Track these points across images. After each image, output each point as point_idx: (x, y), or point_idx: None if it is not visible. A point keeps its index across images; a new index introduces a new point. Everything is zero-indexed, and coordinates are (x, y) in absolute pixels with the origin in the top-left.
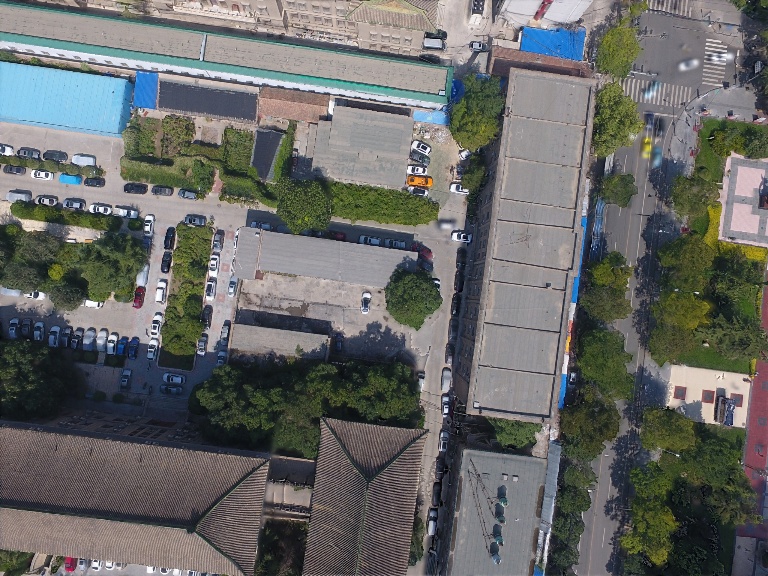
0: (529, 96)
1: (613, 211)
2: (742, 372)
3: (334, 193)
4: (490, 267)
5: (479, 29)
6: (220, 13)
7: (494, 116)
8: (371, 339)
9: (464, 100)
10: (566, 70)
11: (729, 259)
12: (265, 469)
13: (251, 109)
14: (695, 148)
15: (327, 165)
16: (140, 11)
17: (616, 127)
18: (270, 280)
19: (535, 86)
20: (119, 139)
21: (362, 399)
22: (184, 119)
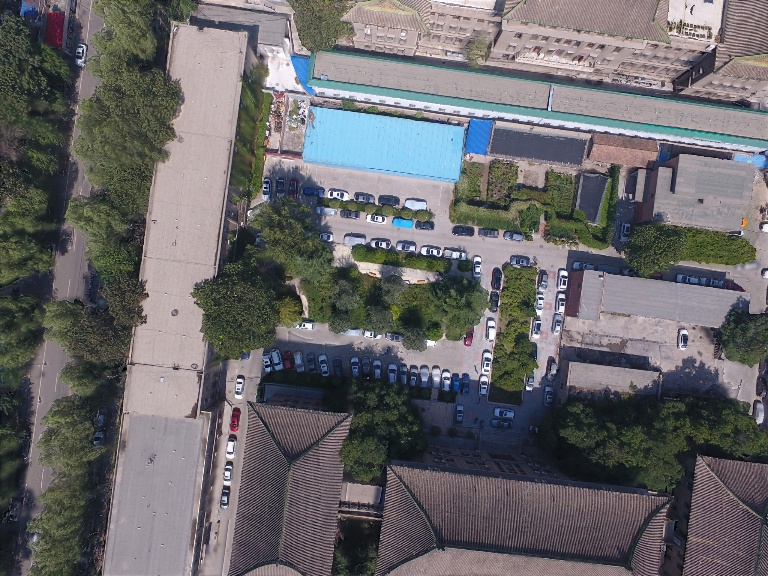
0: None
1: None
2: None
3: None
4: None
5: None
6: (562, 63)
7: None
8: (686, 373)
9: None
10: None
11: None
12: (666, 507)
13: (578, 154)
14: None
15: (668, 210)
16: (466, 59)
17: None
18: None
19: None
20: (448, 183)
21: (723, 436)
22: None
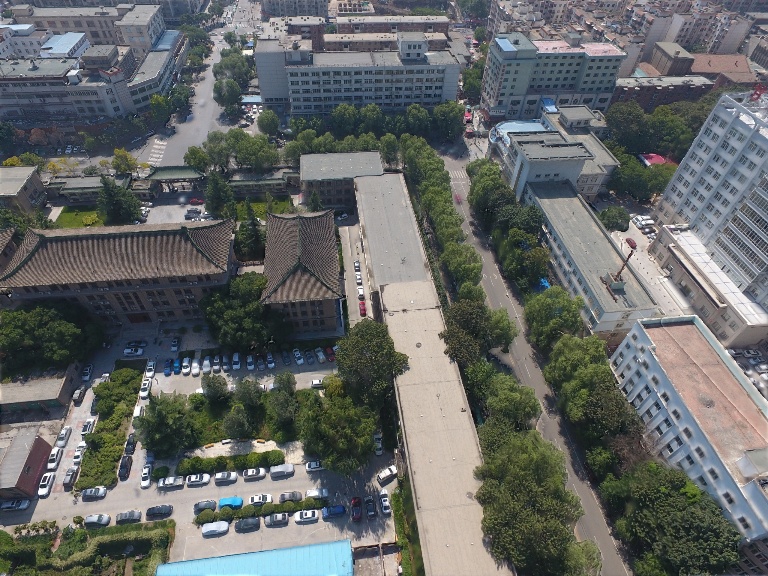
0: None
1: None
2: None
3: None
4: None
5: None
6: None
7: None
8: None
9: None
10: None
11: None
12: None
13: None
14: None
15: None
16: None
17: None
18: None
19: None
20: None
21: None
22: None
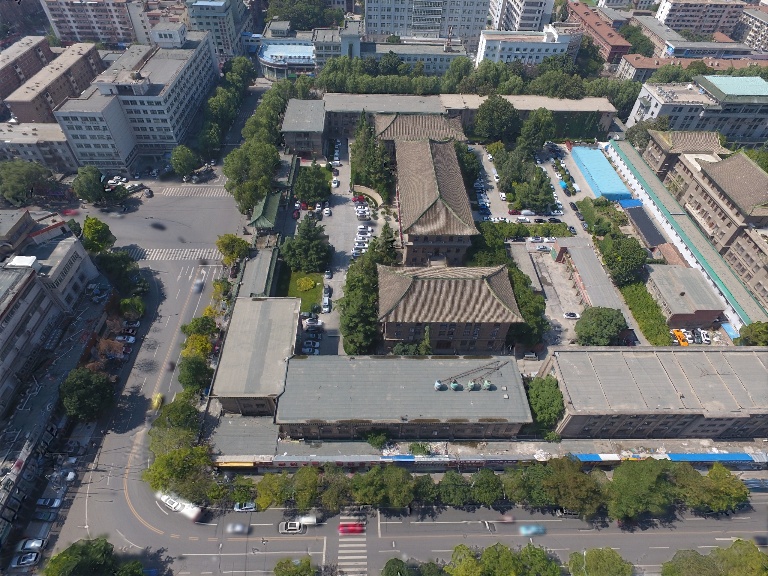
0: None
1: None
2: None
3: (637, 285)
4: (666, 350)
5: None
6: None
7: None
8: None
9: None
10: None
11: None
12: (472, 233)
13: (657, 243)
14: None
15: (656, 271)
16: None
17: None
18: (557, 266)
19: None
20: None
21: None
22: None
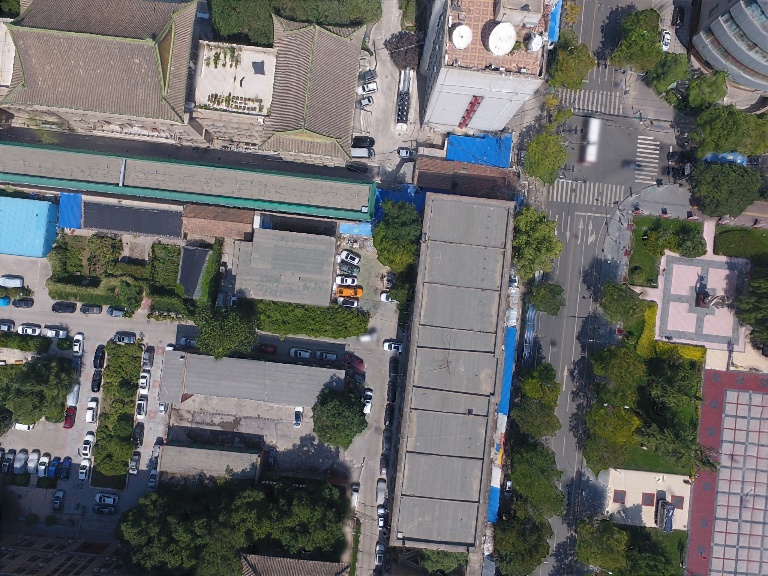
0: (446, 220)
1: (547, 314)
2: (682, 474)
3: (261, 309)
4: (410, 396)
5: (406, 134)
6: (140, 136)
7: (413, 239)
8: (304, 452)
9: (382, 224)
10: (492, 179)
11: (666, 359)
12: None
13: (176, 226)
14: (629, 248)
15: (250, 286)
16: (64, 129)
17: (533, 253)
18: (201, 395)
19: (452, 210)
20: (46, 259)
21: (286, 530)
22: (109, 238)
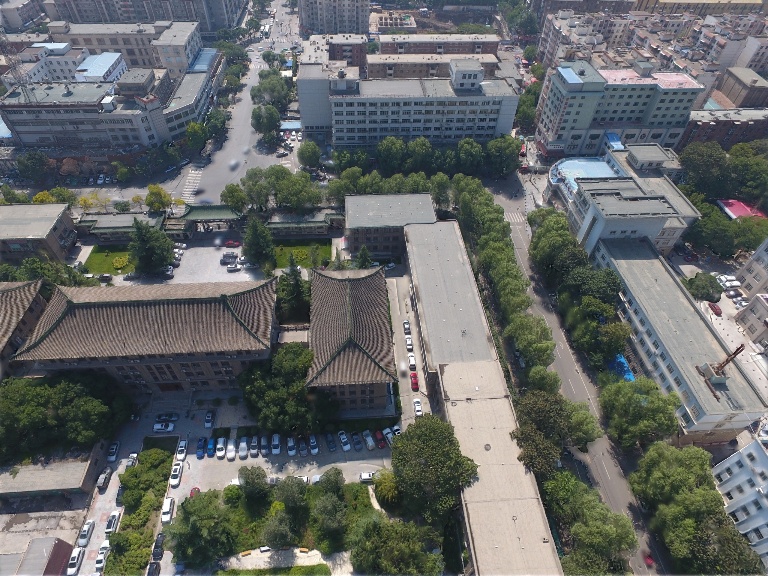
0: None
1: None
2: None
3: None
4: None
5: None
6: None
7: None
8: None
9: None
10: None
11: None
12: None
13: None
14: None
15: None
16: None
17: None
18: None
19: None
20: None
21: None
22: None
